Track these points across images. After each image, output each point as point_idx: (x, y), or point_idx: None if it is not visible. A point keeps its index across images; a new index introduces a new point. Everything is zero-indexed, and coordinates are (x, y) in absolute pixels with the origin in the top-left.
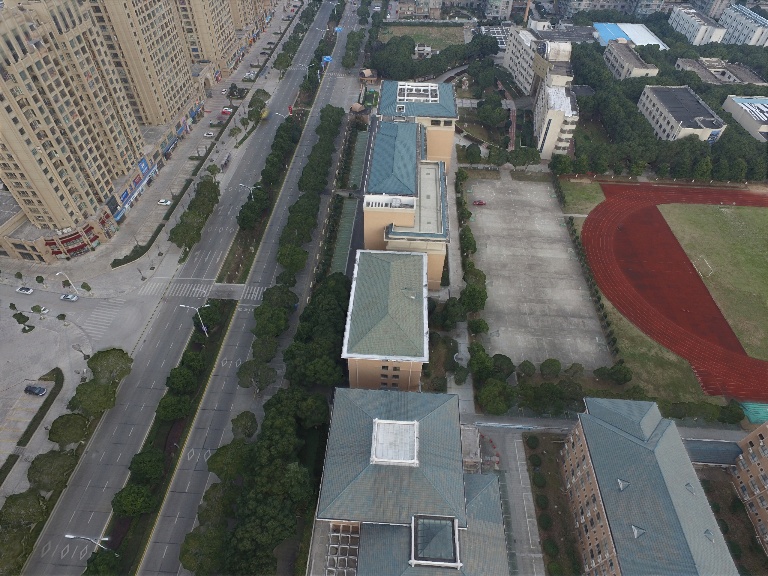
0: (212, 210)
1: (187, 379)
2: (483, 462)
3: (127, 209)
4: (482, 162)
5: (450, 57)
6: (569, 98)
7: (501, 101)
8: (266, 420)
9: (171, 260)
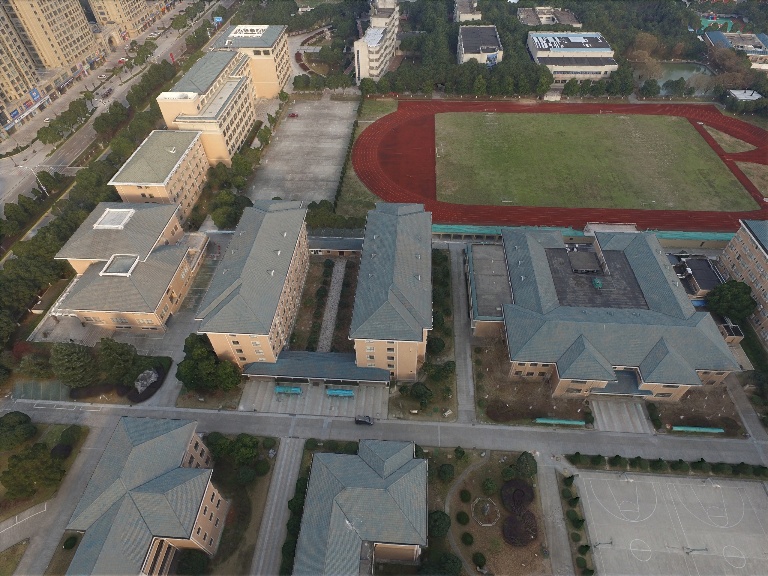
0: (79, 122)
1: (18, 211)
2: (207, 256)
3: (18, 125)
4: (312, 89)
5: (320, 14)
6: (382, 35)
7: None
8: None
9: (41, 155)
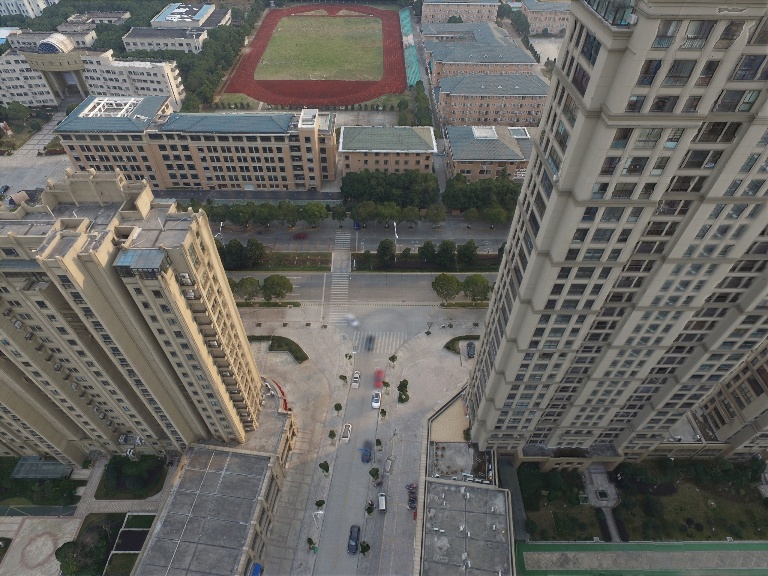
0: None
1: None
2: None
3: None
4: None
5: None
6: (136, 61)
7: (55, 118)
8: (477, 188)
9: (295, 314)
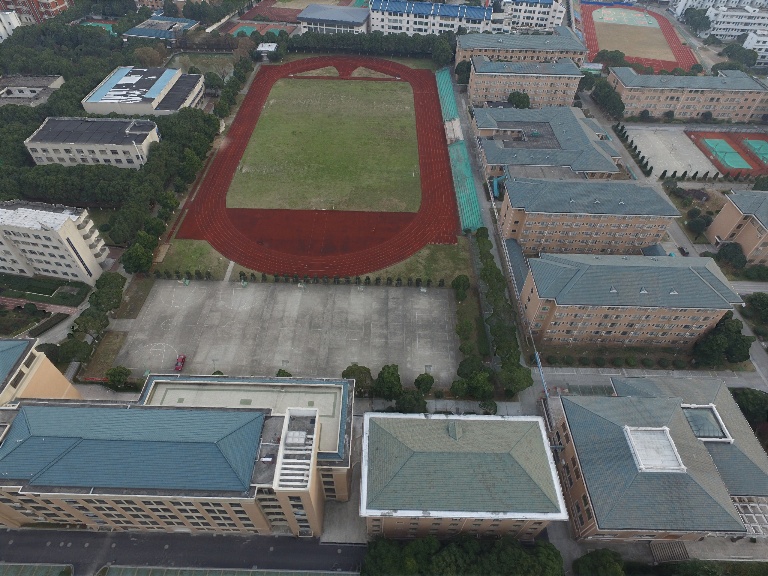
0: None
1: None
2: None
3: None
4: None
5: None
6: (22, 208)
7: None
8: None
9: None
